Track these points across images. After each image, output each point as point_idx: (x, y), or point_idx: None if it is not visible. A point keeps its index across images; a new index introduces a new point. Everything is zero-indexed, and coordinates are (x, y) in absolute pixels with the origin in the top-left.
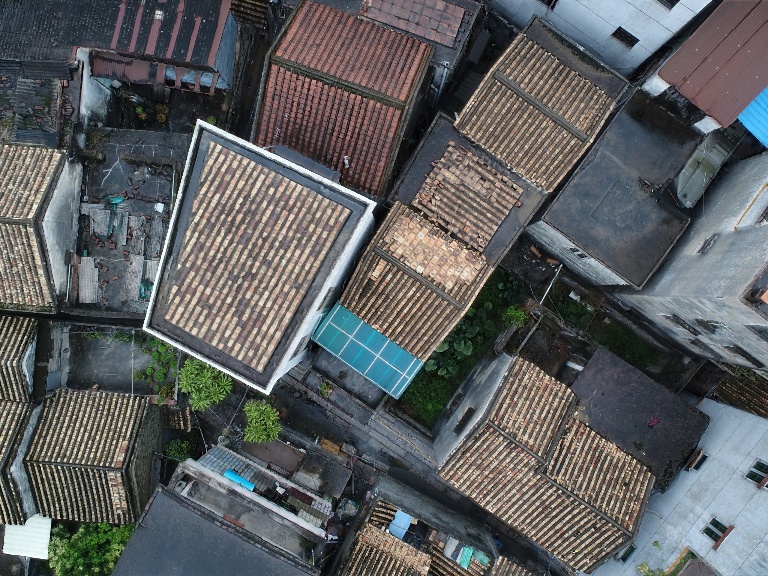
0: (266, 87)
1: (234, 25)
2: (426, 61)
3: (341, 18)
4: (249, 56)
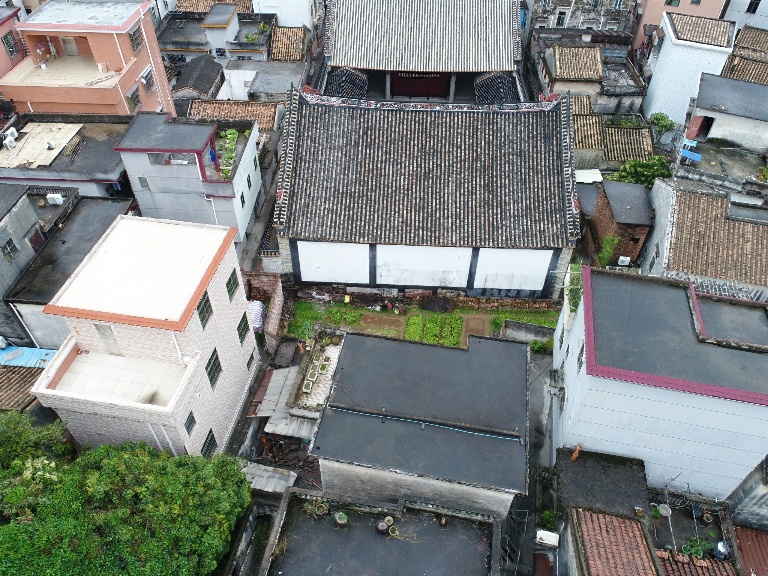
0: None
1: None
2: None
3: None
4: None
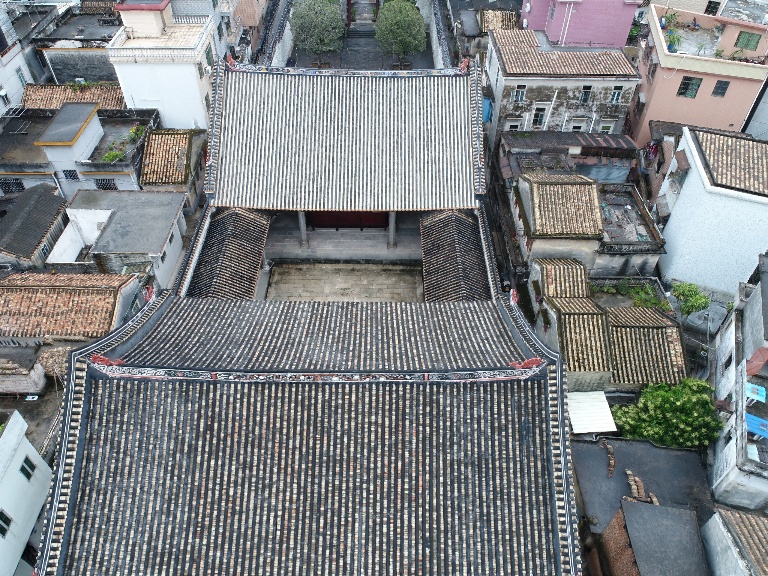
0: None
1: None
2: None
3: None
4: None
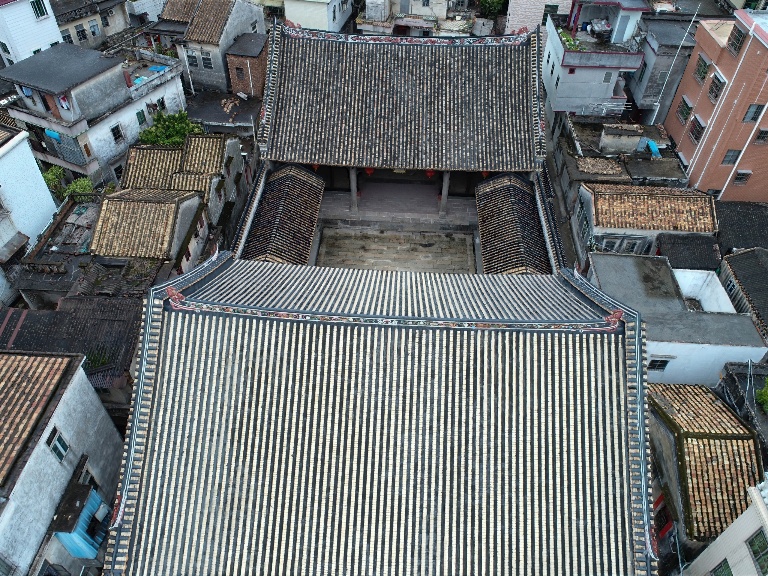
0: None
1: None
2: None
3: None
4: None
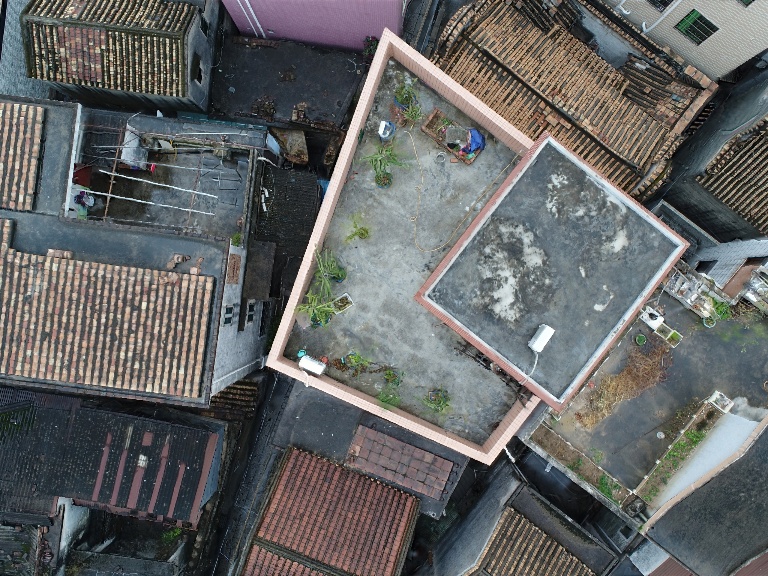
0: (247, 559)
1: (221, 433)
2: (411, 526)
3: (327, 473)
4: (236, 445)
